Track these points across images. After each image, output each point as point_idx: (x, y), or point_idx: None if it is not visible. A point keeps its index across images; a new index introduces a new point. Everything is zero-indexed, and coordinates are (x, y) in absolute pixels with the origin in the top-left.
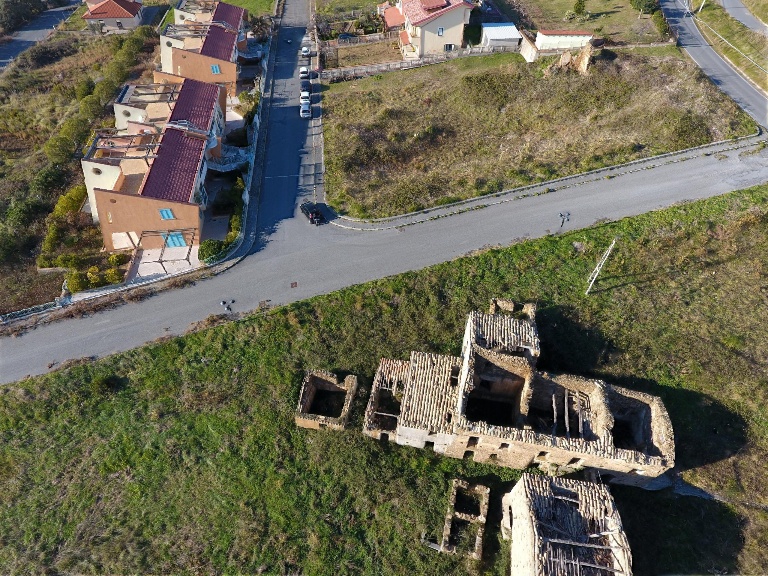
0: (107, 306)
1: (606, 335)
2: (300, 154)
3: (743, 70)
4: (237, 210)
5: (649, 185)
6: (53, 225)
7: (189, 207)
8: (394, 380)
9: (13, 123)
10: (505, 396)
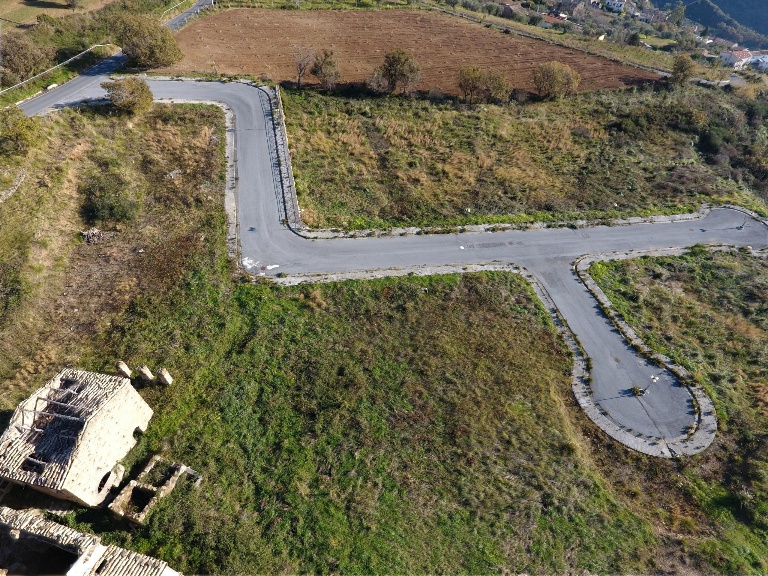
0: None
1: None
2: None
3: None
4: None
5: None
6: None
7: None
8: None
9: None
10: None
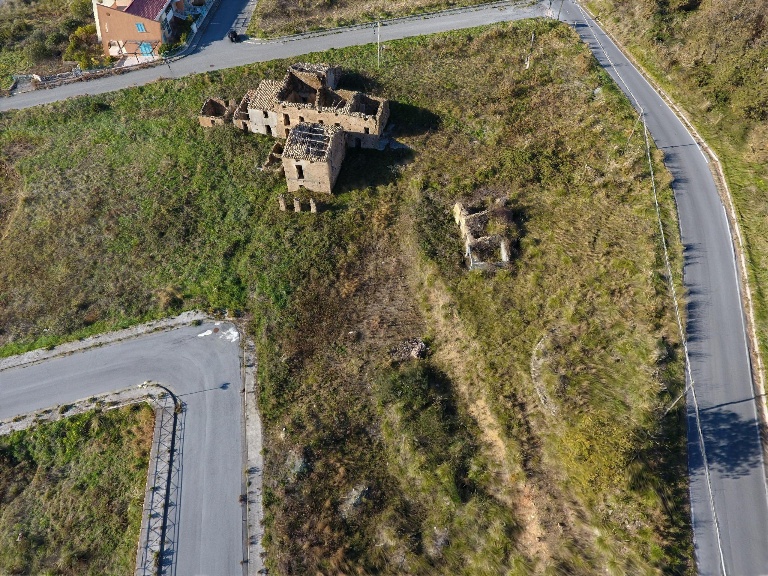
0: (102, 76)
1: None
2: (238, 14)
3: None
4: (186, 32)
5: (447, 22)
6: (73, 40)
7: (154, 23)
8: None
9: (51, 5)
10: None
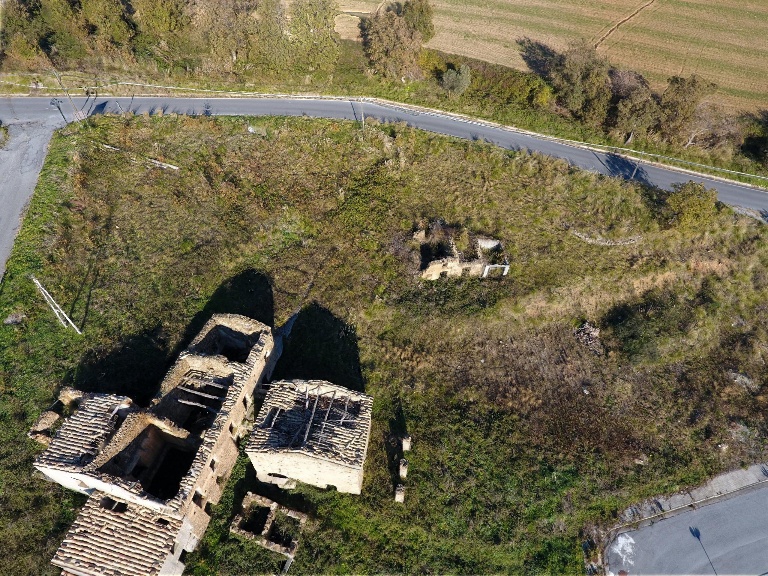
0: None
1: (137, 333)
2: None
3: None
4: None
5: None
6: None
7: None
8: None
9: None
10: (160, 452)
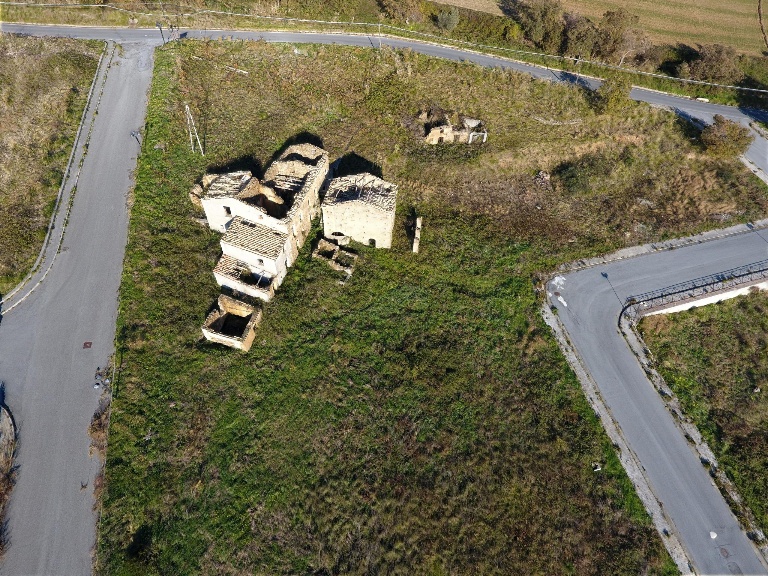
0: None
1: (240, 156)
2: None
3: (23, 21)
4: None
5: (120, 100)
6: None
7: None
8: (235, 267)
9: None
10: None
